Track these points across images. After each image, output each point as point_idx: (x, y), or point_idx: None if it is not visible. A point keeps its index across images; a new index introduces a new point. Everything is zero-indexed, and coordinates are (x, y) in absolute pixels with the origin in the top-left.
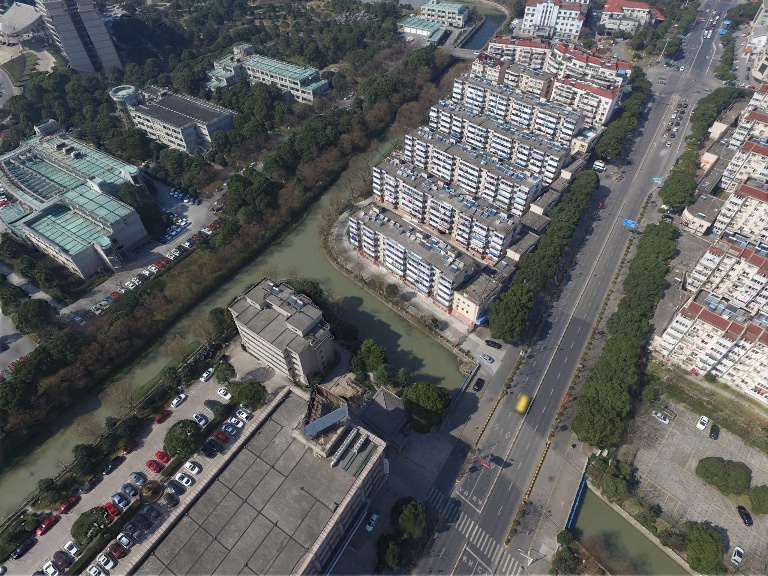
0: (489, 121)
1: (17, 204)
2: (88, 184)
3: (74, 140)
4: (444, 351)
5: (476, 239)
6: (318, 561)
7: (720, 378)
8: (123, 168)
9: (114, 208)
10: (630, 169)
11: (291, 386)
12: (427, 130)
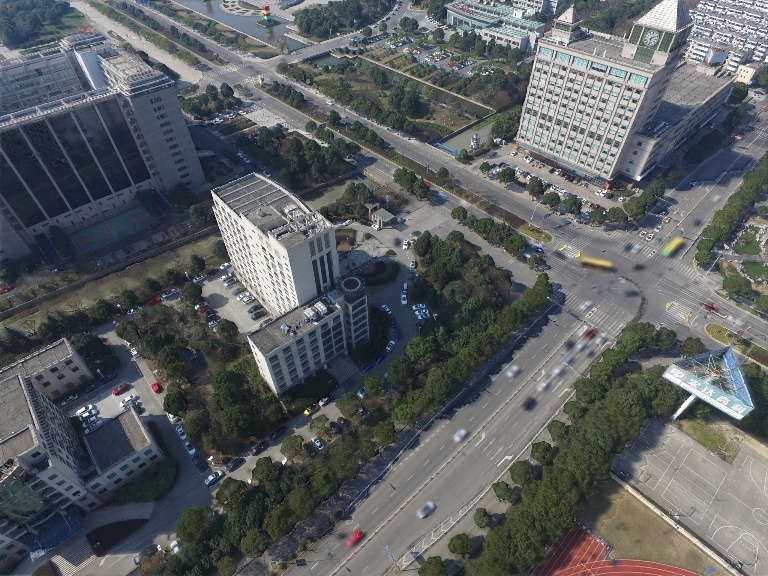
0: (744, 8)
1: (465, 25)
2: (510, 15)
3: (484, 0)
4: None
5: None
6: None
7: None
8: (530, 8)
9: (532, 24)
10: None
11: None
12: (704, 8)
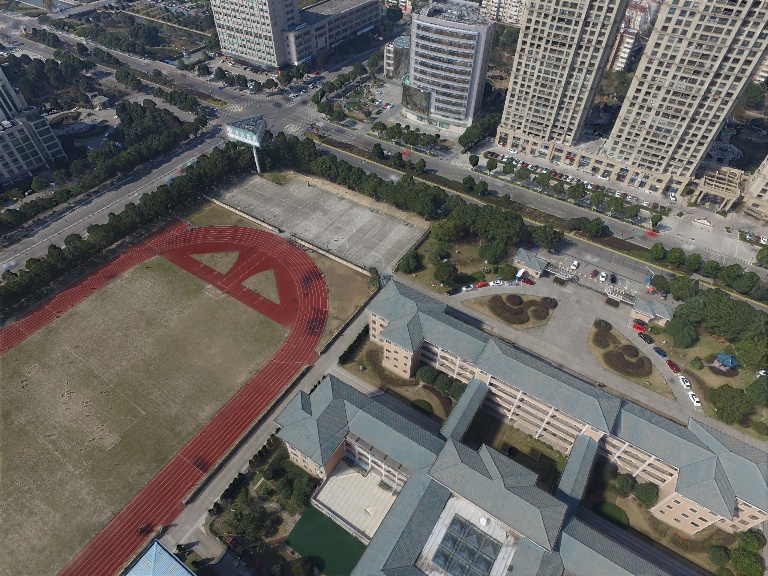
0: None
1: None
2: None
3: None
4: (403, 19)
5: None
6: (361, 18)
7: (502, 20)
8: None
9: None
10: None
11: None
12: None
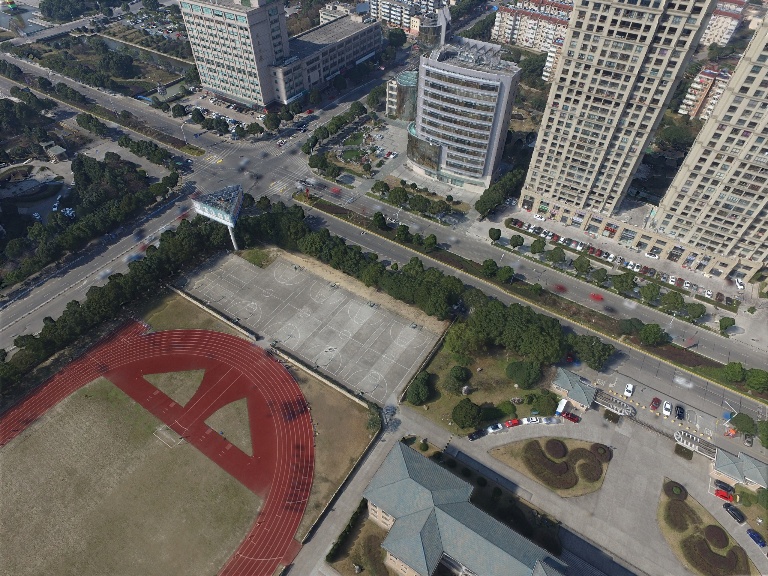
0: None
1: None
2: None
3: None
4: None
5: (423, 8)
6: None
7: (516, 44)
8: None
9: None
10: (508, 1)
11: (349, 13)
12: None
